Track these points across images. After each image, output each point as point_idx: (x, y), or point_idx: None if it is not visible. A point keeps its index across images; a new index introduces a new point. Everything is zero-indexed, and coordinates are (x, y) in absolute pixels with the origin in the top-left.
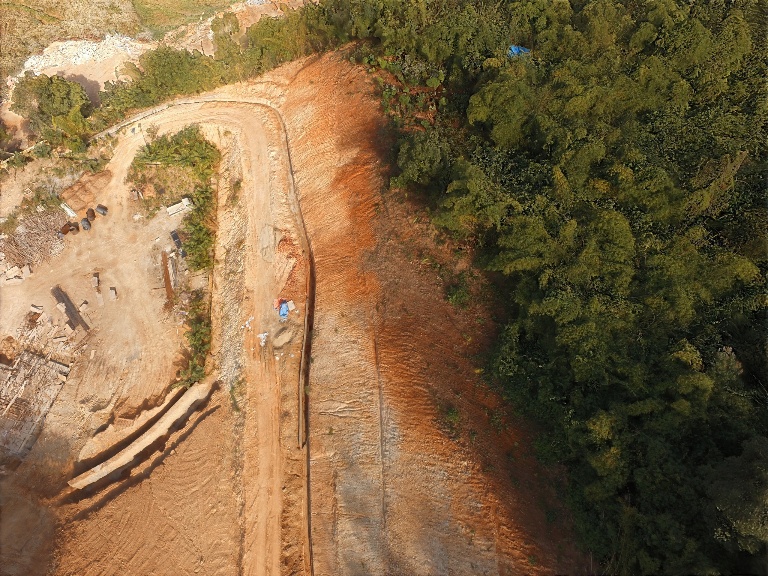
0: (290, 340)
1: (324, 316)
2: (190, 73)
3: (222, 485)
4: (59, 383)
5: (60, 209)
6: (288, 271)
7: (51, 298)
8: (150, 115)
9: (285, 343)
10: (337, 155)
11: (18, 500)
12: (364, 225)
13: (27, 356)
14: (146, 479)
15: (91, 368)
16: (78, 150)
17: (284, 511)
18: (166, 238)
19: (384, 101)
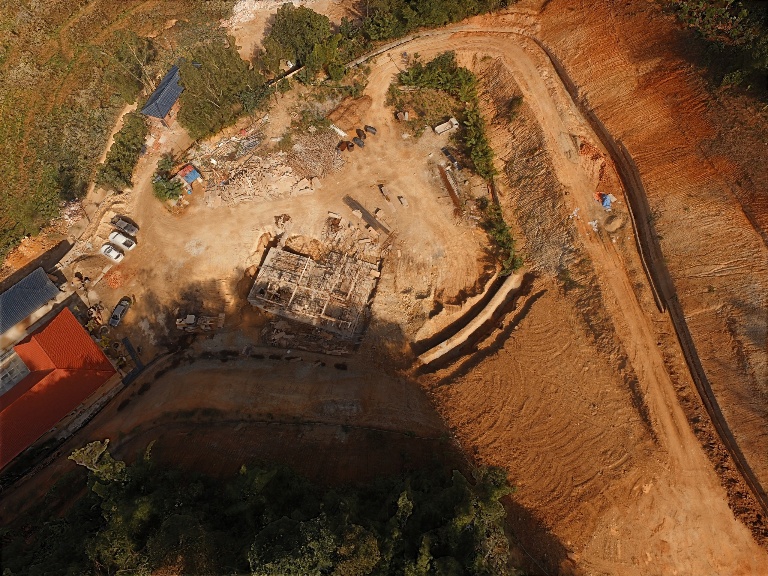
0: (621, 226)
1: (664, 200)
2: (442, 5)
3: (584, 349)
4: (373, 278)
5: (330, 129)
6: (597, 170)
7: (345, 206)
8: (397, 46)
9: (618, 228)
10: (632, 66)
11: (373, 373)
12: (695, 119)
13: (336, 256)
14: (501, 349)
15: (402, 265)
16: (340, 76)
17: (667, 361)
18: (438, 154)
19: (682, 15)
